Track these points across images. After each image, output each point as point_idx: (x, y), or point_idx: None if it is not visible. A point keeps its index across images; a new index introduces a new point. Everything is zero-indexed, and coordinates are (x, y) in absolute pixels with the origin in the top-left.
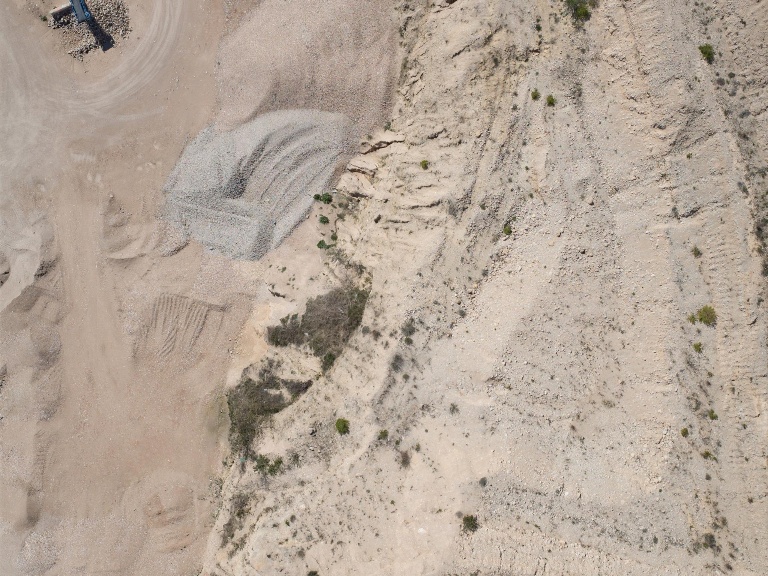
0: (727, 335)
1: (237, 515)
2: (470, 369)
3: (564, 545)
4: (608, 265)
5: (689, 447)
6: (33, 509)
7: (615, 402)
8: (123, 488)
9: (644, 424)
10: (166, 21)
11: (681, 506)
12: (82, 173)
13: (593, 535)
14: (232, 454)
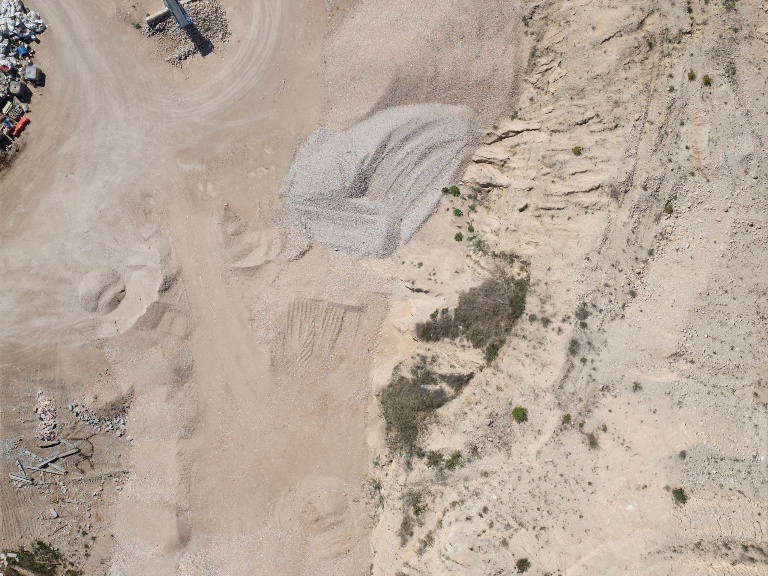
0: None
1: (415, 513)
2: (650, 347)
3: None
4: None
5: None
6: (184, 529)
7: None
8: (274, 498)
9: None
10: (266, 22)
11: None
12: (192, 183)
13: None
14: (390, 453)
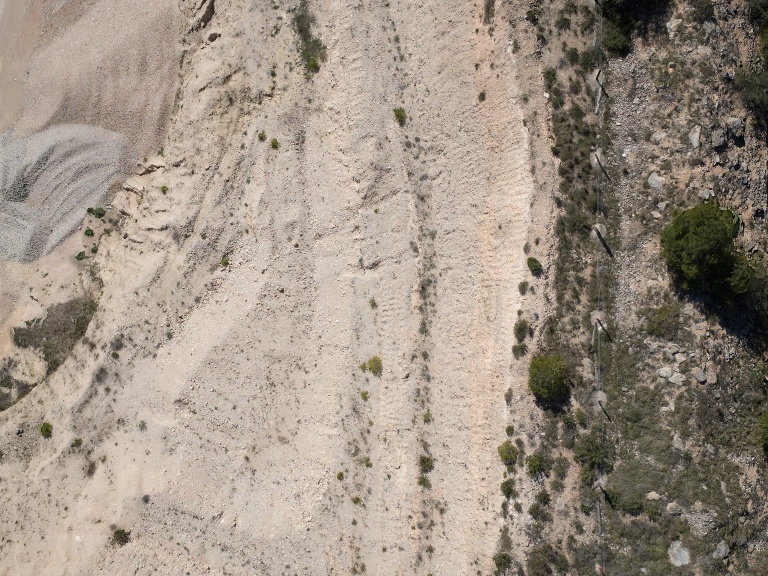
0: (387, 386)
1: None
2: (163, 389)
3: (206, 570)
4: (303, 306)
5: (342, 491)
6: None
7: (289, 439)
8: None
9: (310, 464)
10: None
11: (325, 547)
12: None
13: (238, 564)
14: None
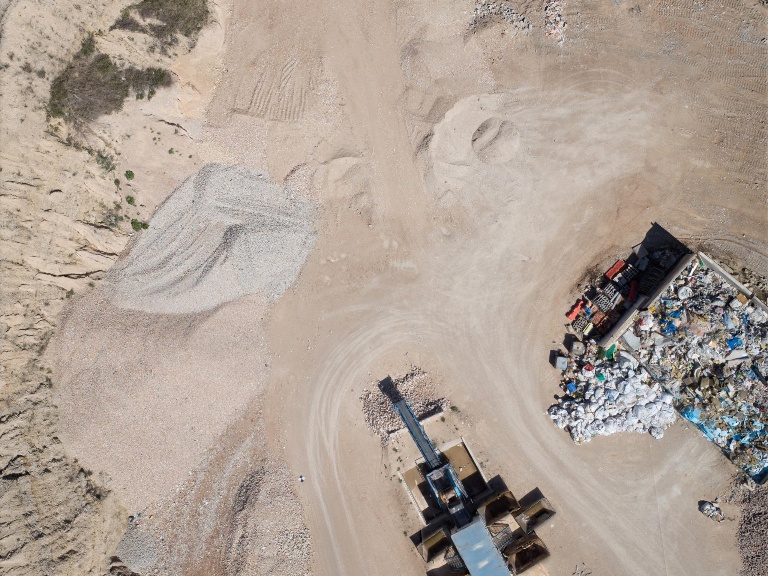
0: None
1: None
2: None
3: None
4: None
5: None
6: None
7: None
8: None
9: None
10: (324, 409)
11: None
12: (403, 248)
13: None
14: None
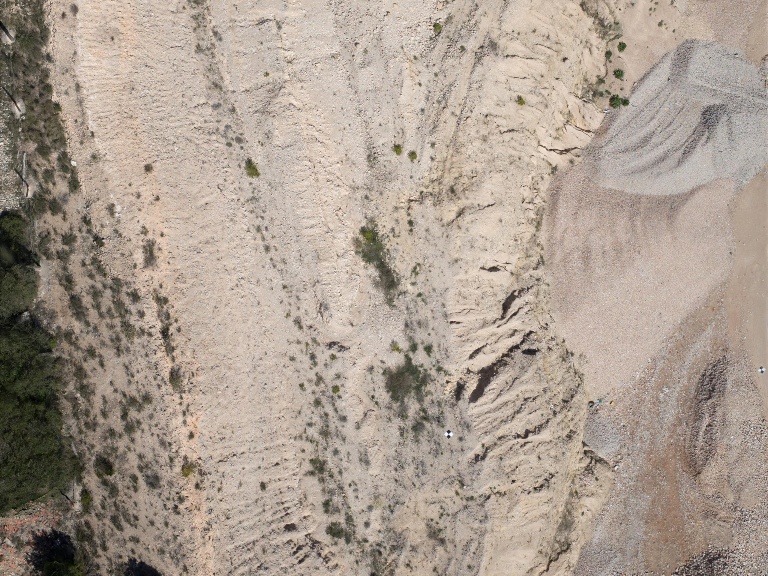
0: None
1: None
2: None
3: None
4: None
5: None
6: None
7: None
8: None
9: None
10: None
11: None
12: None
13: None
14: None
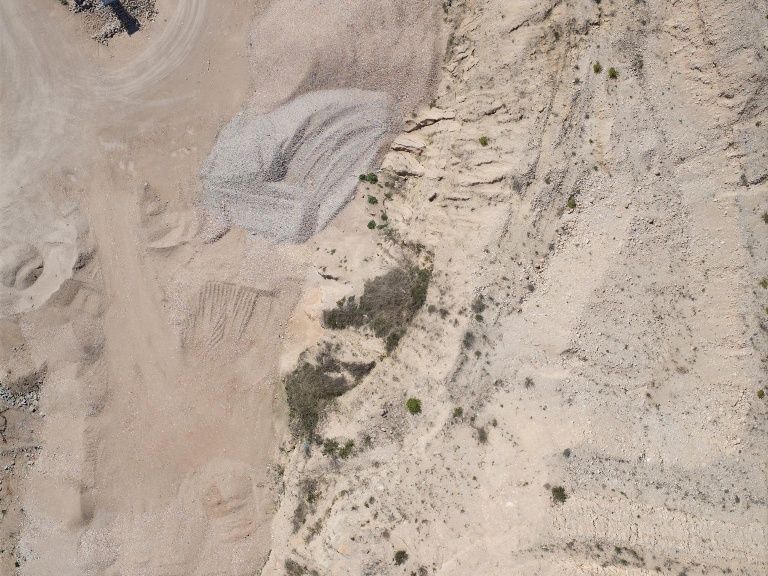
0: None
1: (308, 500)
2: (544, 343)
3: (651, 510)
4: (676, 234)
5: (765, 408)
6: (87, 507)
7: (688, 368)
8: (179, 480)
9: (718, 388)
10: (193, 2)
11: (760, 465)
12: (114, 161)
13: (677, 498)
14: (293, 440)
